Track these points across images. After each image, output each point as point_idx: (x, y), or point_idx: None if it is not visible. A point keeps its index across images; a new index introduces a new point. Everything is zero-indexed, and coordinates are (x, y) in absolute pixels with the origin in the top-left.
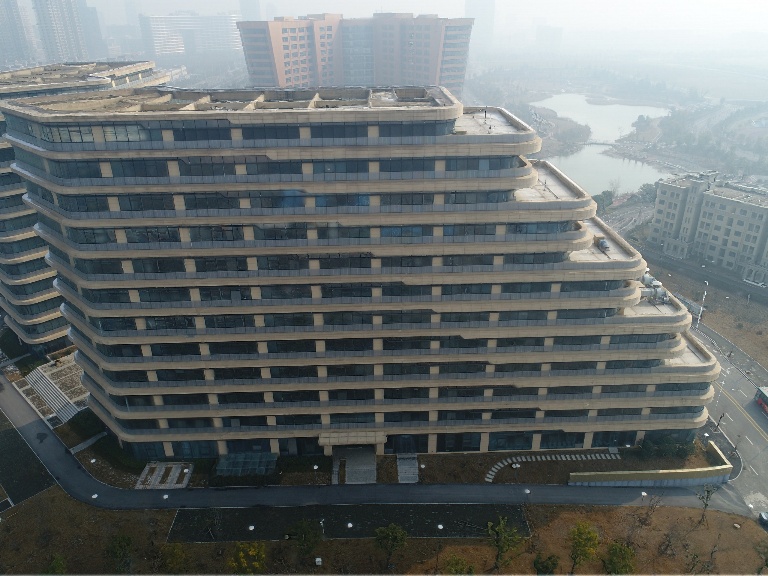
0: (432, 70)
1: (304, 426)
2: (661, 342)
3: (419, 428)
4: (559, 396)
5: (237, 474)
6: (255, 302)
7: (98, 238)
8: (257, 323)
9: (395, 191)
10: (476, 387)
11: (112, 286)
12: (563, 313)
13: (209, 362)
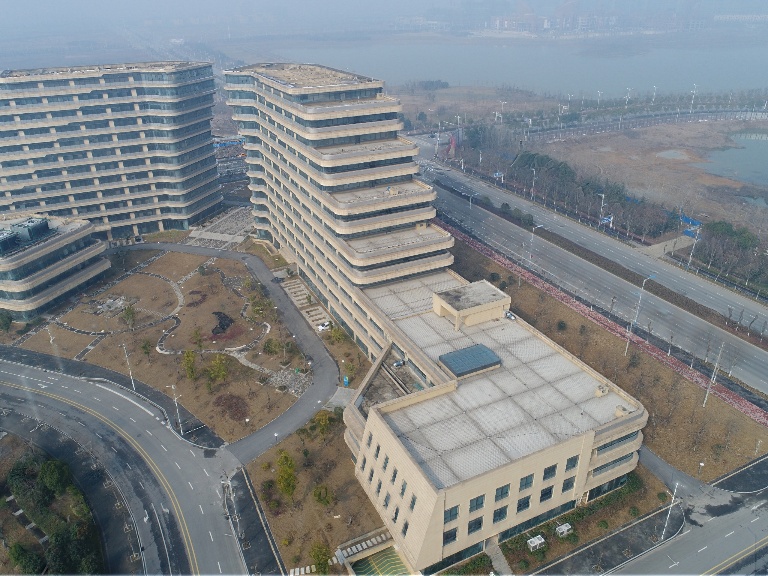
0: None
1: None
2: None
3: None
4: None
5: None
6: None
7: None
8: None
9: None
10: None
11: None
12: None
13: None
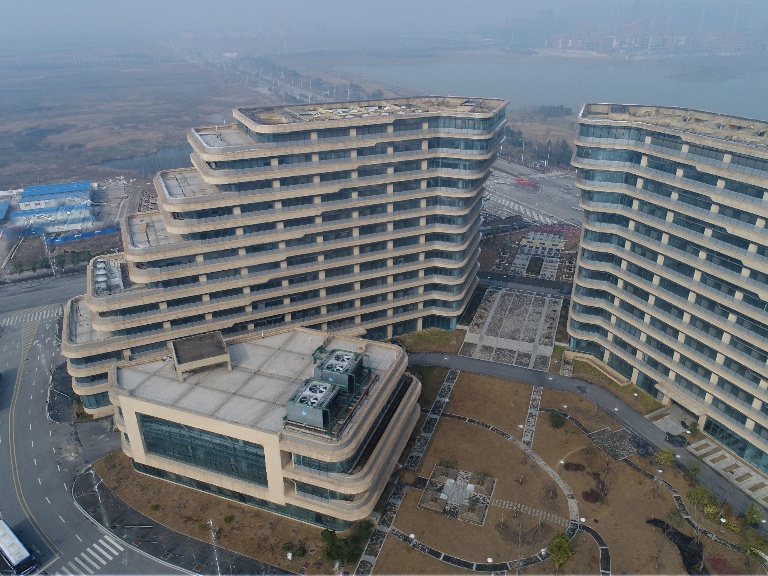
0: None
1: None
2: None
3: None
4: None
5: None
6: None
7: None
8: None
9: None
10: None
11: None
12: None
13: None
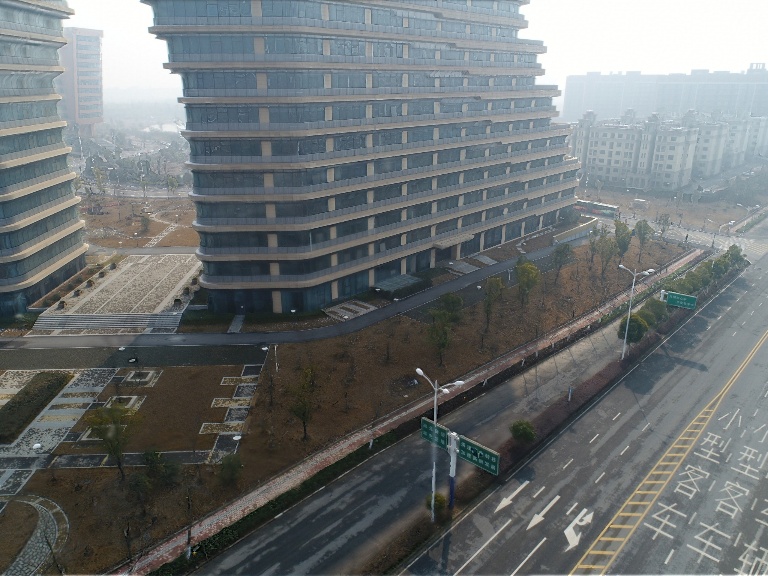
0: (67, 82)
1: (422, 241)
2: (565, 143)
3: (479, 228)
4: (532, 189)
5: (405, 286)
6: (404, 118)
7: (309, 48)
8: (403, 139)
9: (481, 21)
10: (502, 187)
11: (320, 100)
12: (535, 123)
13: (374, 182)
